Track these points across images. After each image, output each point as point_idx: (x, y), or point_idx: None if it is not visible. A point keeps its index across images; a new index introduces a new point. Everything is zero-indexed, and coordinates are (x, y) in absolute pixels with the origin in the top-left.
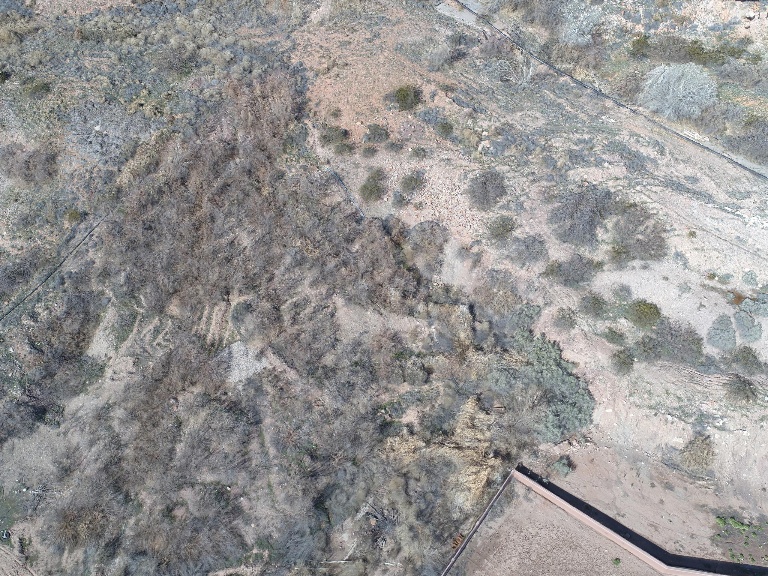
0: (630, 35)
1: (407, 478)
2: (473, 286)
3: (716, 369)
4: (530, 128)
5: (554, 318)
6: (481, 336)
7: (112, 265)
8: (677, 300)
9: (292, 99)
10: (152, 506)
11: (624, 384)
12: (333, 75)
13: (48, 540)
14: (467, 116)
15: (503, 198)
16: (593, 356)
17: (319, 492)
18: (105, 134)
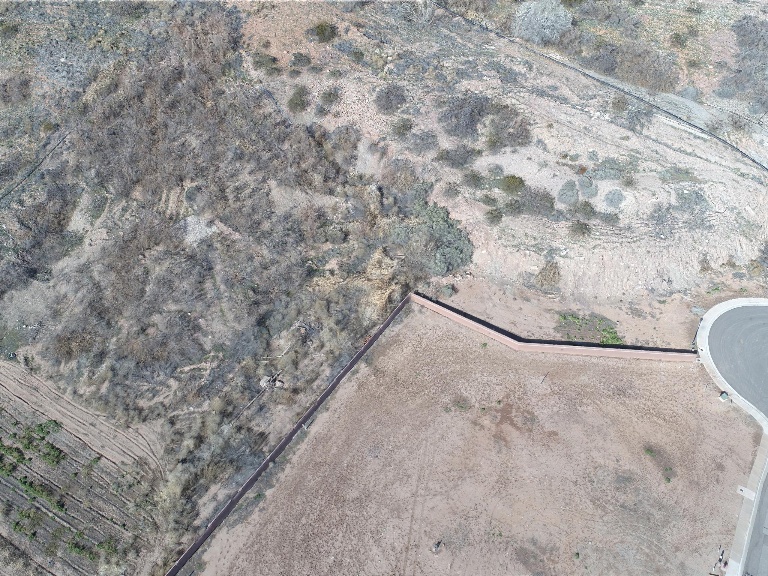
0: None
1: (329, 302)
2: (381, 173)
3: (563, 218)
4: (426, 53)
5: (443, 190)
6: (388, 208)
7: (83, 164)
8: (537, 173)
9: (228, 34)
10: (129, 328)
11: (495, 231)
12: (262, 15)
13: (47, 357)
14: (375, 46)
15: (403, 105)
16: (472, 214)
17: (261, 315)
18: (70, 64)
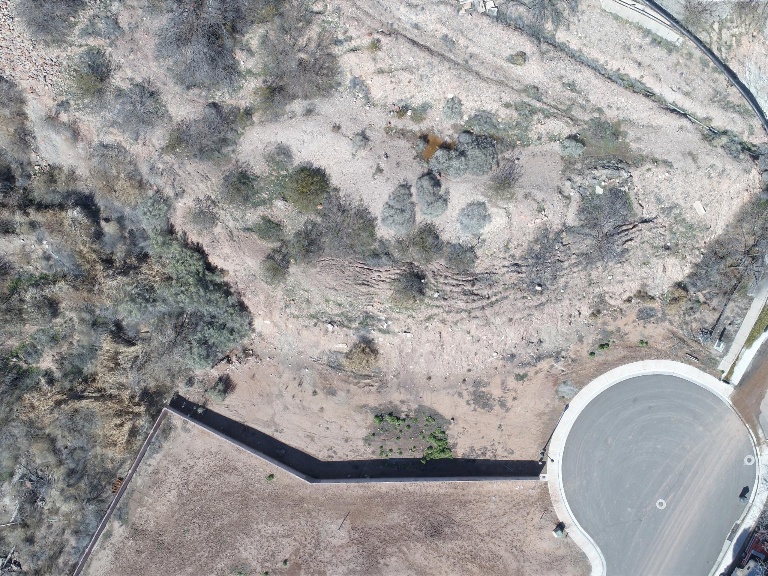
0: None
1: (53, 437)
2: (86, 166)
3: (387, 260)
4: None
5: (191, 213)
6: (112, 241)
7: None
8: (350, 161)
9: None
10: None
11: (279, 295)
12: None
13: None
14: None
15: (80, 15)
16: (241, 263)
17: None
18: None
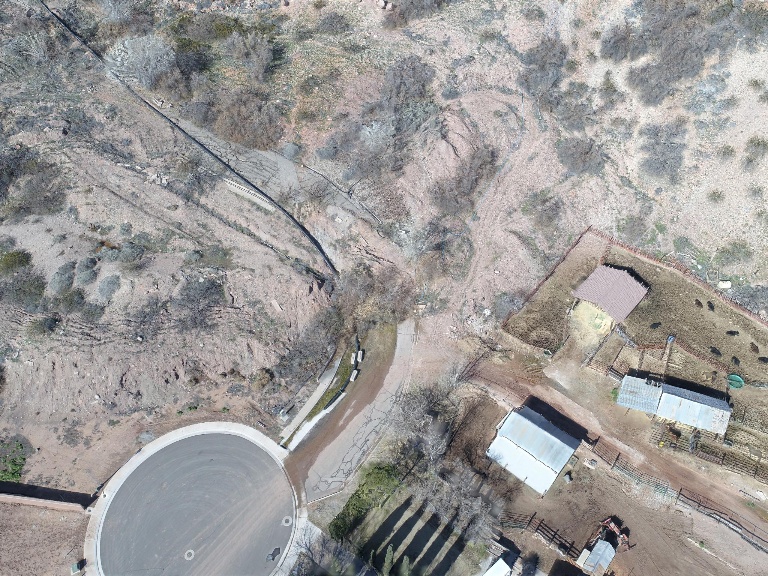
0: (180, 13)
1: None
2: None
3: (41, 309)
4: (1, 97)
5: None
6: None
7: None
8: (49, 249)
9: None
10: None
11: None
12: None
13: None
14: None
15: None
16: None
17: None
18: None
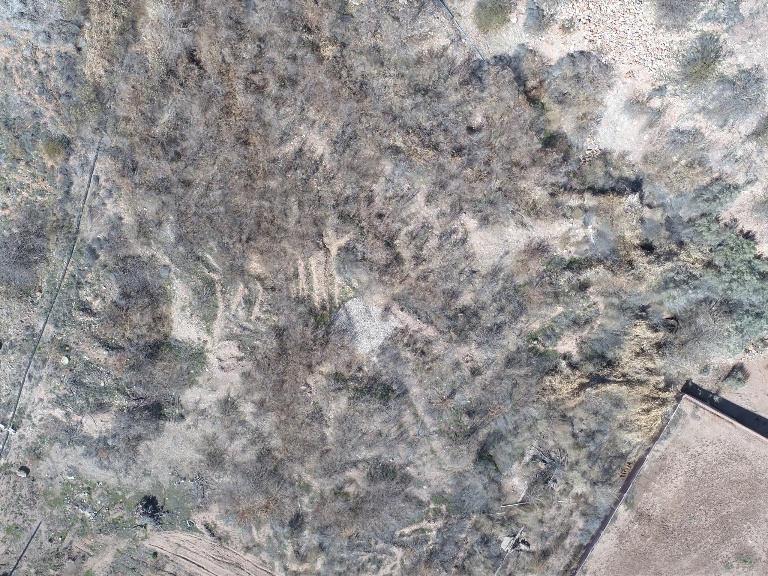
0: None
1: (572, 419)
2: (643, 152)
3: None
4: None
5: (755, 201)
6: (650, 227)
7: (147, 215)
8: None
9: None
10: (321, 487)
11: None
12: None
13: (231, 522)
14: None
15: (710, 0)
16: None
17: (481, 443)
18: None
